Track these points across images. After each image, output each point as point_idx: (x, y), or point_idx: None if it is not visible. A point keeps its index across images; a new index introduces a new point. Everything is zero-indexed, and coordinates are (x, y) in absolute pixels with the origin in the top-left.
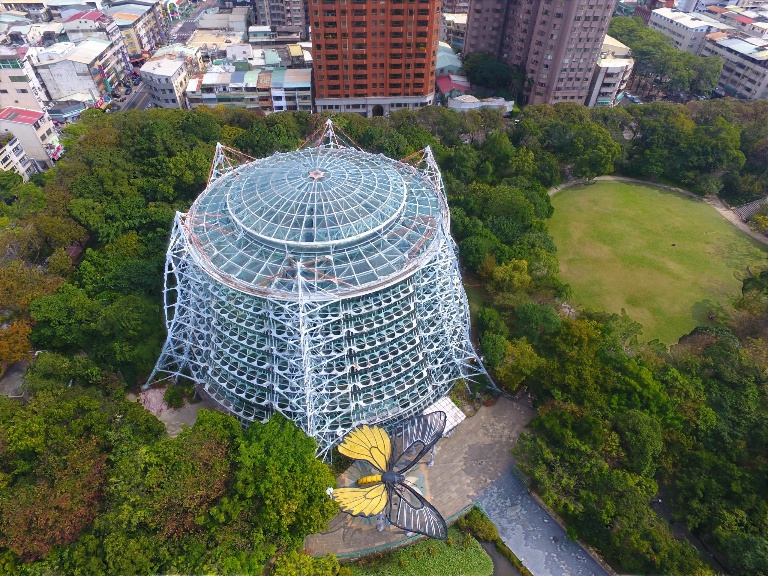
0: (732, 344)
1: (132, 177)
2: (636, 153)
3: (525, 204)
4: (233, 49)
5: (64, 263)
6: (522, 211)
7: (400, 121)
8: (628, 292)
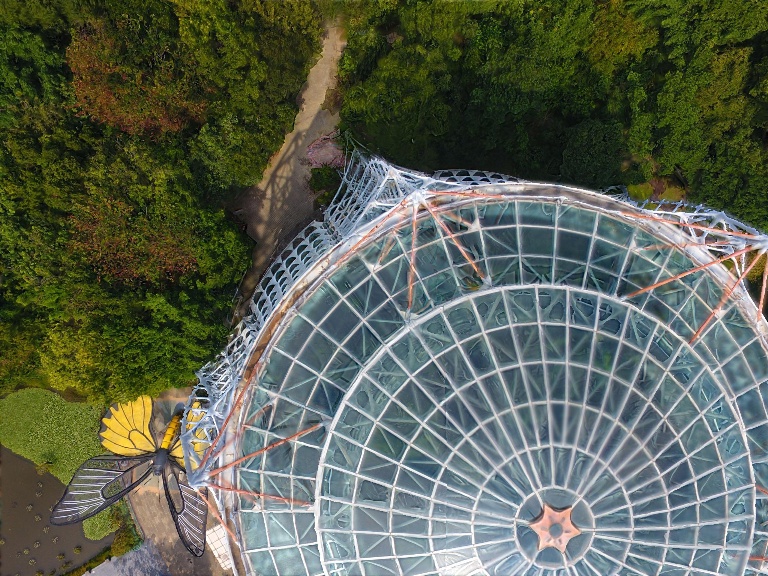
0: None
1: None
2: None
3: None
4: None
5: None
6: None
7: None
8: None
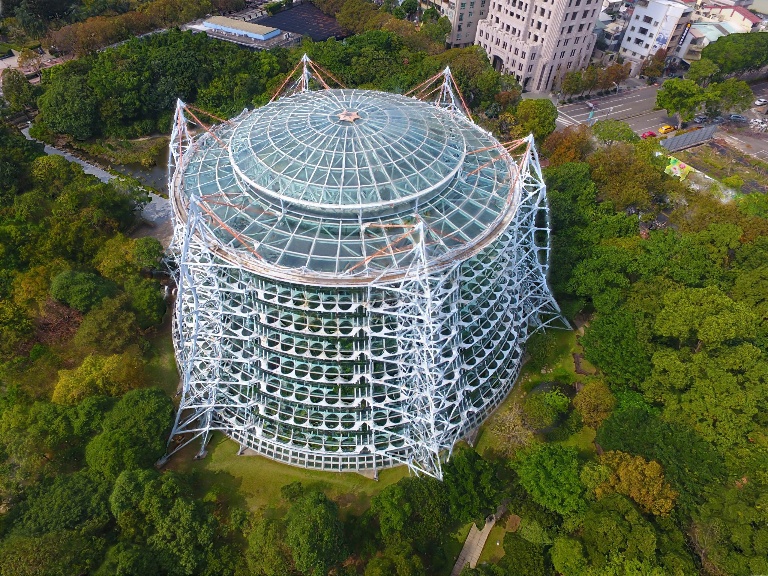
0: None
1: None
2: None
3: None
4: None
5: (631, 199)
6: None
7: None
8: None
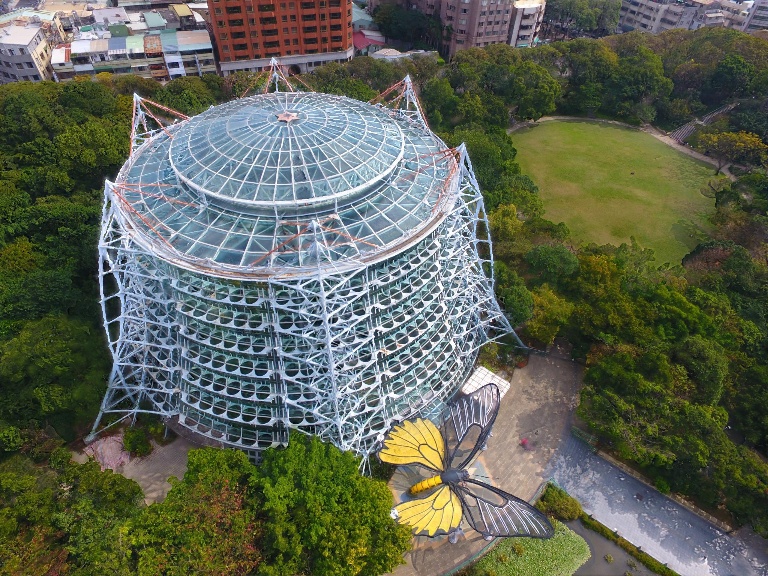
0: (748, 253)
1: (3, 169)
2: (570, 90)
3: (493, 147)
4: (102, 12)
5: None
6: (491, 155)
7: (328, 77)
8: (610, 224)
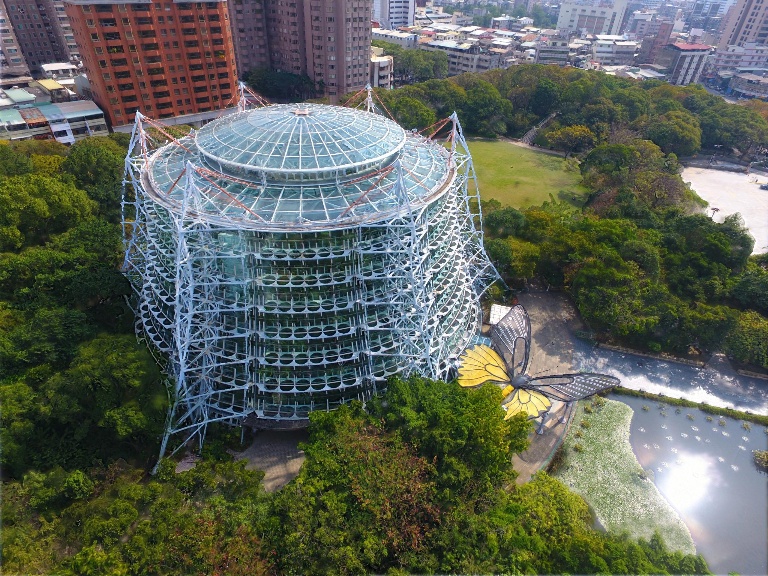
0: (627, 188)
1: None
2: (438, 118)
3: None
4: None
5: None
6: None
7: None
8: (517, 202)
